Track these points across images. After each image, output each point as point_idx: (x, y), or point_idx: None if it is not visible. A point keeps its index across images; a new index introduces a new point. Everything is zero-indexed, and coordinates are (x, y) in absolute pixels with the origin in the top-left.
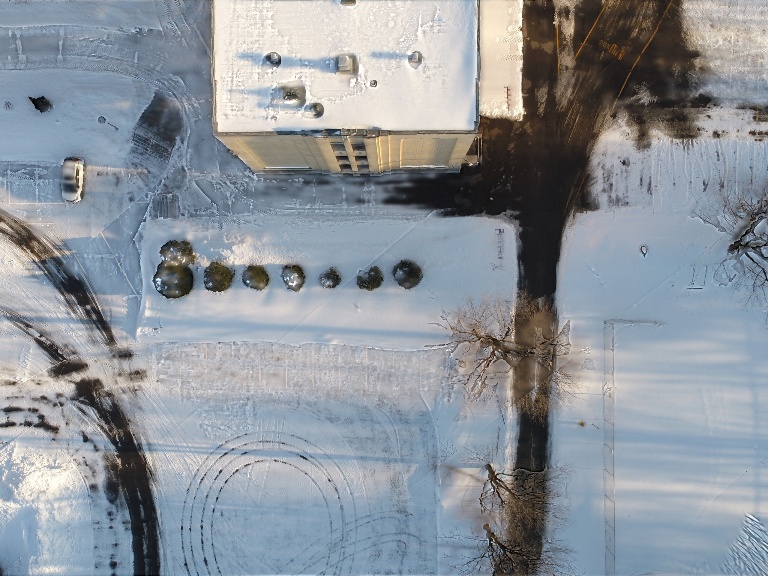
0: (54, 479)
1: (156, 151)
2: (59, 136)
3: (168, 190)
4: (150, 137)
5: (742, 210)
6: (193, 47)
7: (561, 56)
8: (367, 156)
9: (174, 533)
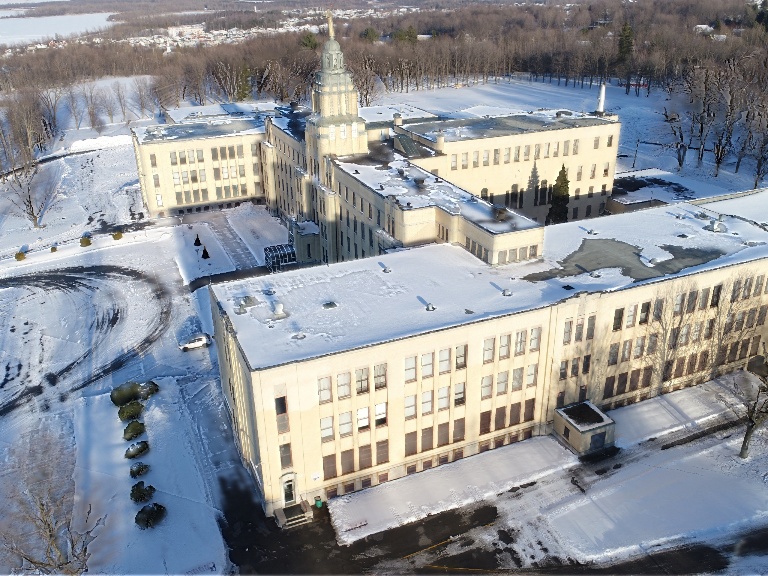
0: None
1: None
2: None
3: None
4: None
5: None
6: None
7: (422, 553)
8: None
9: None
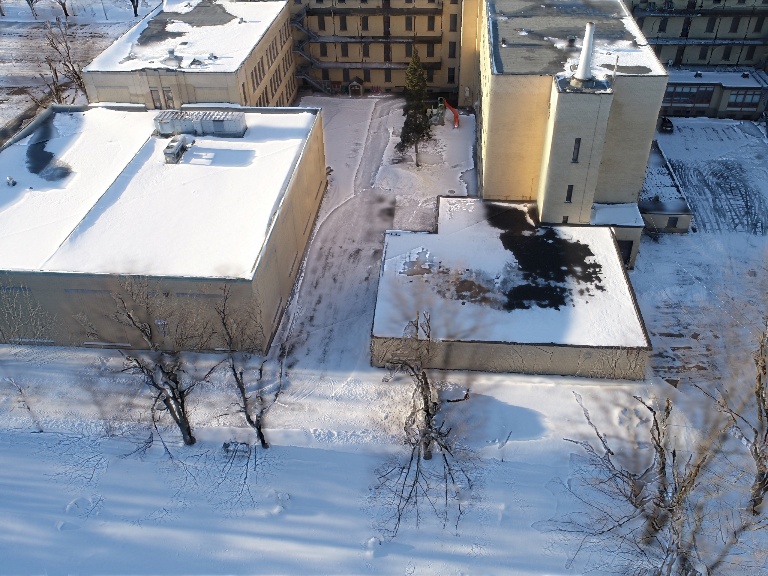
0: None
1: None
2: None
3: None
4: None
5: (131, 5)
6: None
7: None
8: None
9: None
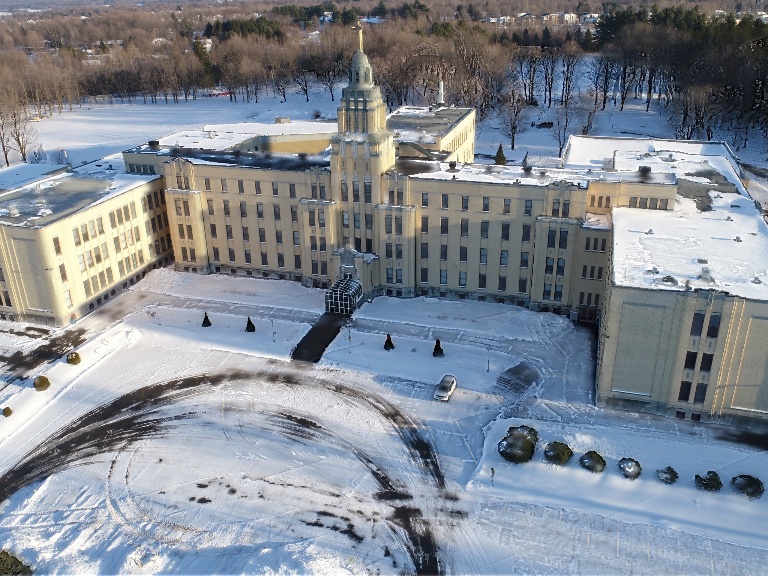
0: (342, 575)
1: (514, 388)
2: (443, 369)
3: None
4: (513, 379)
5: None
6: (553, 350)
7: None
8: (714, 353)
9: None
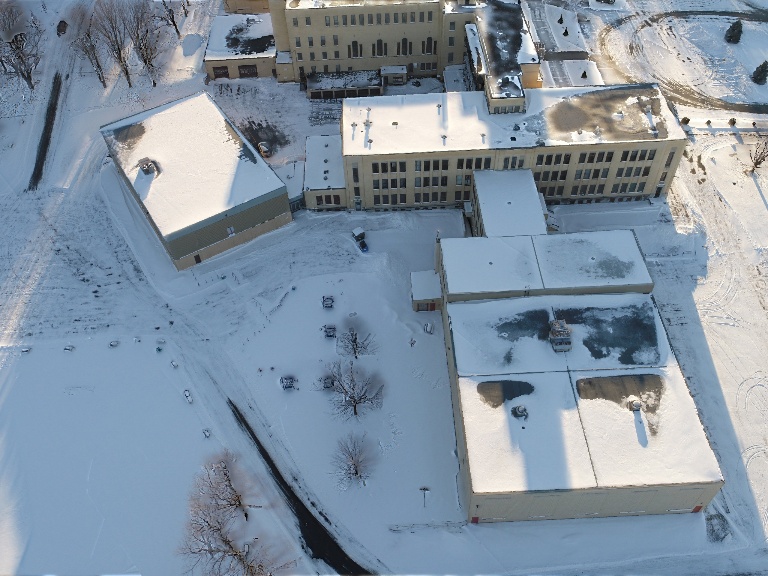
0: None
1: (568, 6)
2: None
3: (580, 3)
4: (564, 5)
5: None
6: None
7: None
8: None
9: (693, 8)
